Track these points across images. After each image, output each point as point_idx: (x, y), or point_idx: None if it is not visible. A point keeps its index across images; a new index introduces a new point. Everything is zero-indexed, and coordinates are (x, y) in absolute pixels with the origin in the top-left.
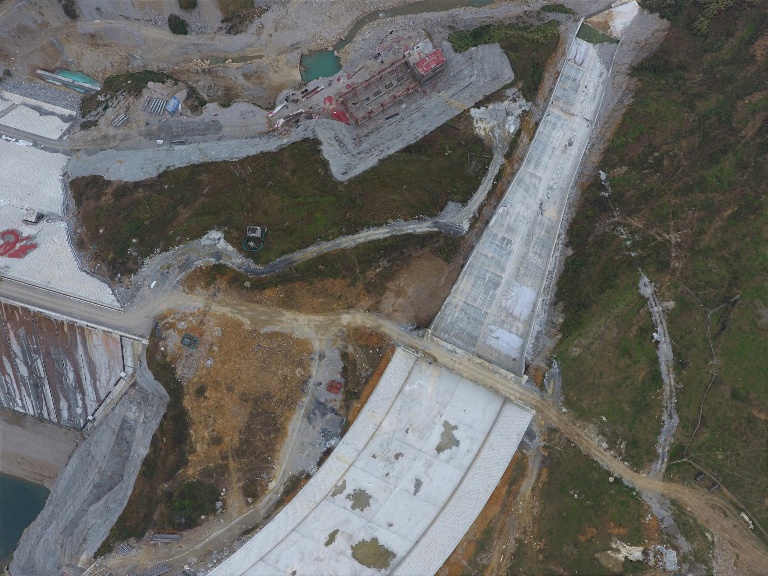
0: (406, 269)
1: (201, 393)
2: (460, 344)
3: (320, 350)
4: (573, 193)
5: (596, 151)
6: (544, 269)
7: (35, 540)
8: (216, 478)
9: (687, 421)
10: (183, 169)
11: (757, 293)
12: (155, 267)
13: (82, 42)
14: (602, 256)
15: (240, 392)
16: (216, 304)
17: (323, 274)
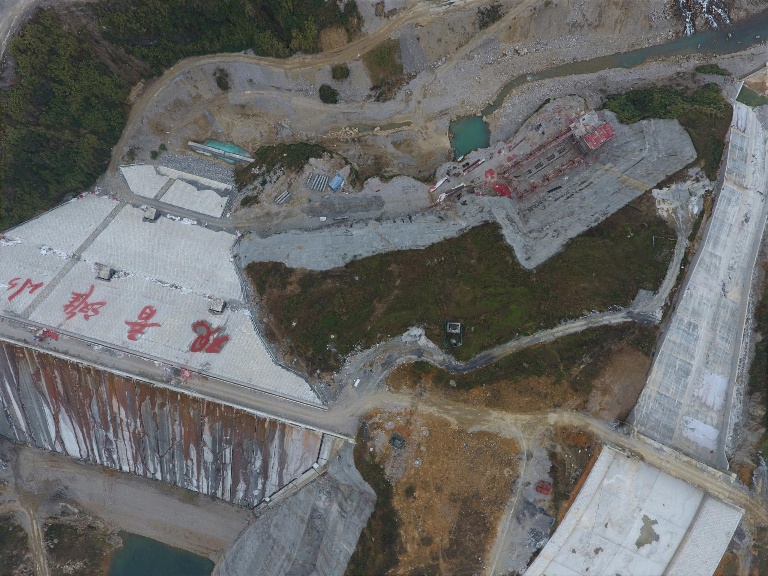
0: (610, 365)
1: (410, 493)
2: (657, 437)
3: (527, 450)
4: (756, 273)
5: None
6: (733, 355)
7: None
8: None
9: None
10: (372, 259)
11: None
12: (358, 365)
13: (232, 113)
14: None
15: (449, 492)
16: (423, 404)
17: (527, 372)
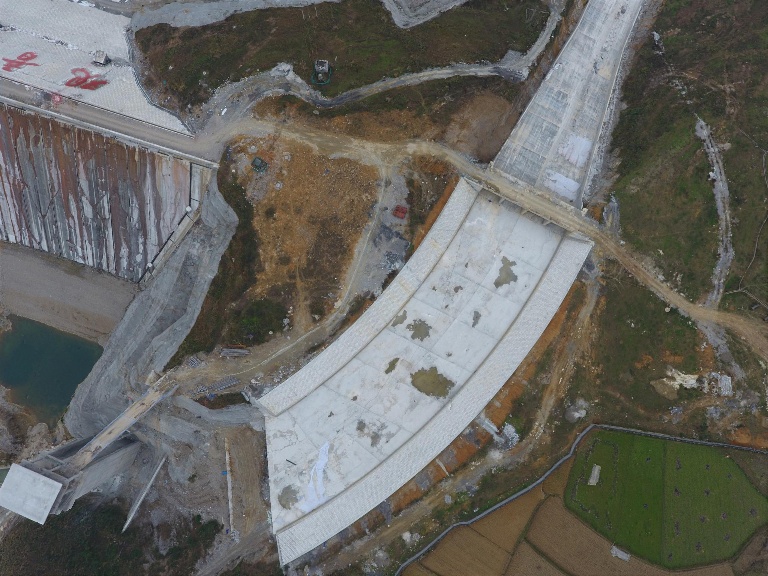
0: (470, 104)
1: (270, 214)
2: None
3: (386, 177)
4: (626, 54)
5: (649, 16)
6: (599, 122)
7: (95, 379)
8: (284, 296)
9: (742, 255)
10: (250, 12)
11: None
12: (226, 95)
13: None
14: (658, 105)
15: (308, 215)
16: (286, 130)
17: (390, 105)
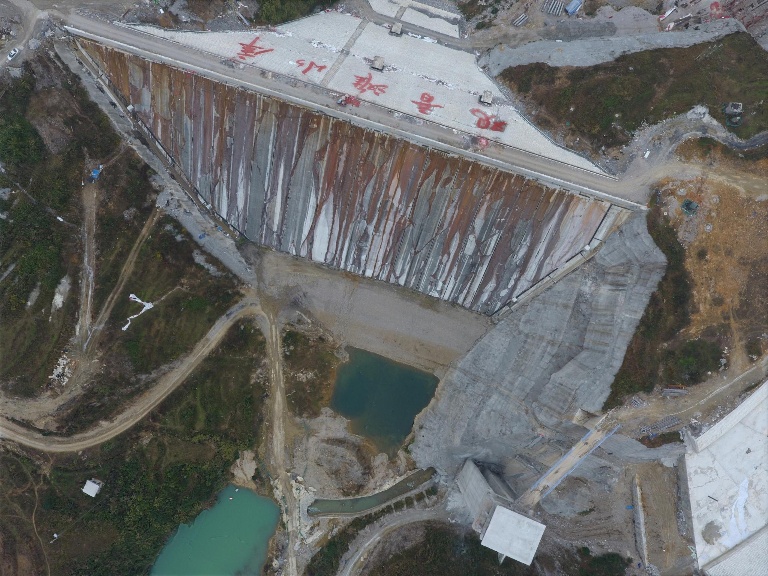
0: None
1: (703, 256)
2: None
3: None
4: None
5: None
6: None
7: (473, 413)
8: (719, 337)
9: None
10: (643, 53)
11: None
12: (647, 138)
13: None
14: None
15: (739, 256)
16: (713, 173)
17: None
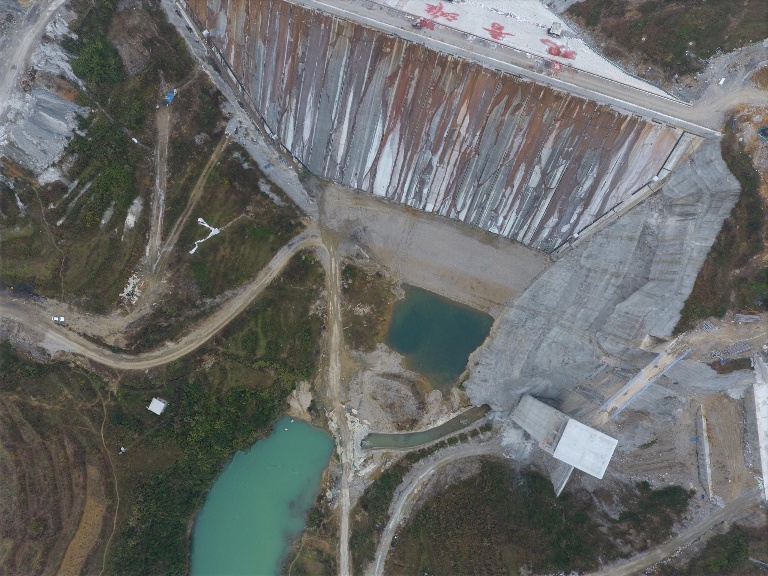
0: None
1: None
2: None
3: None
4: None
5: None
6: None
7: (533, 345)
8: None
9: None
10: None
11: None
12: (722, 65)
13: None
14: None
15: None
16: None
17: None
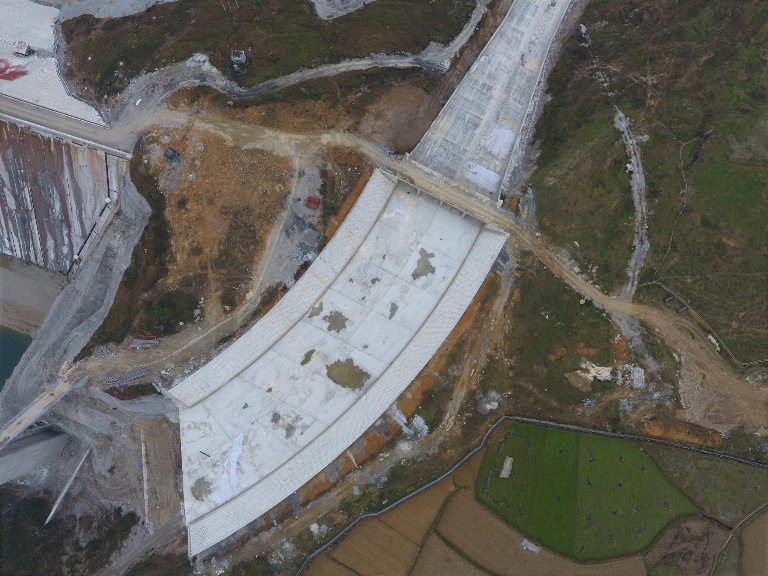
0: (386, 95)
1: (182, 205)
2: None
3: (300, 167)
4: (554, 47)
5: (578, 9)
6: (523, 114)
7: (19, 371)
8: (195, 287)
9: (658, 247)
10: (171, 3)
11: (730, 128)
12: (141, 86)
13: None
14: (580, 97)
15: (220, 205)
16: (199, 120)
17: (305, 96)
